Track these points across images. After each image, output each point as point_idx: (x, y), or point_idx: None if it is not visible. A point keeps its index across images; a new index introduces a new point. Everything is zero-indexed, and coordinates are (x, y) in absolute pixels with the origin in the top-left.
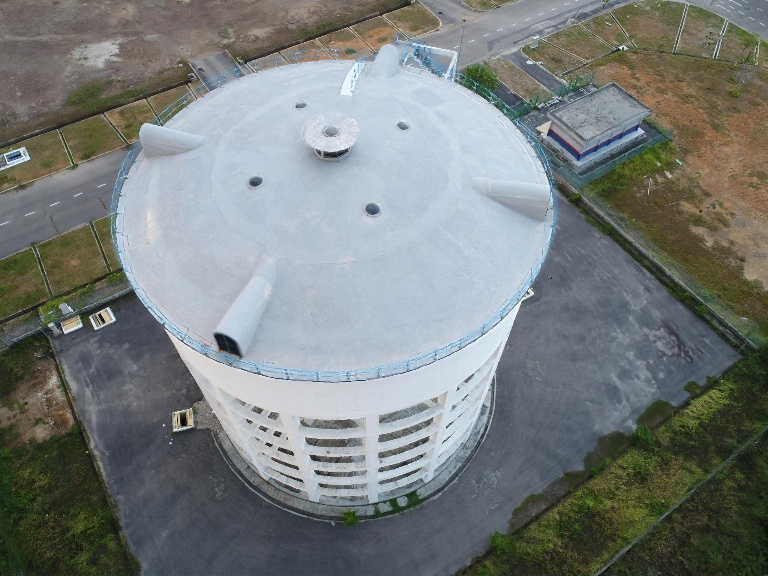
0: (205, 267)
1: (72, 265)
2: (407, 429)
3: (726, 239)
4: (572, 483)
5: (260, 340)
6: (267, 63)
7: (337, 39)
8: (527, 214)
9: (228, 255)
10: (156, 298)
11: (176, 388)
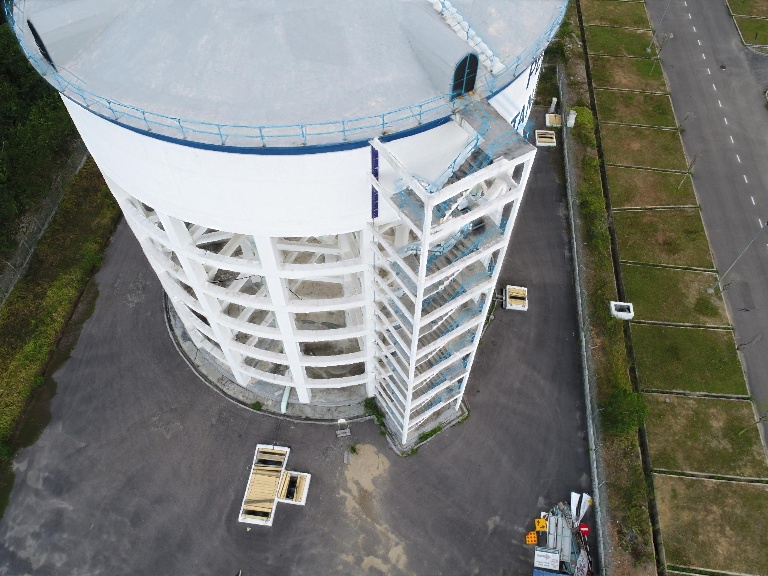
0: None
1: (633, 144)
2: None
3: None
4: (58, 355)
5: None
6: None
7: None
8: None
9: None
10: None
11: None
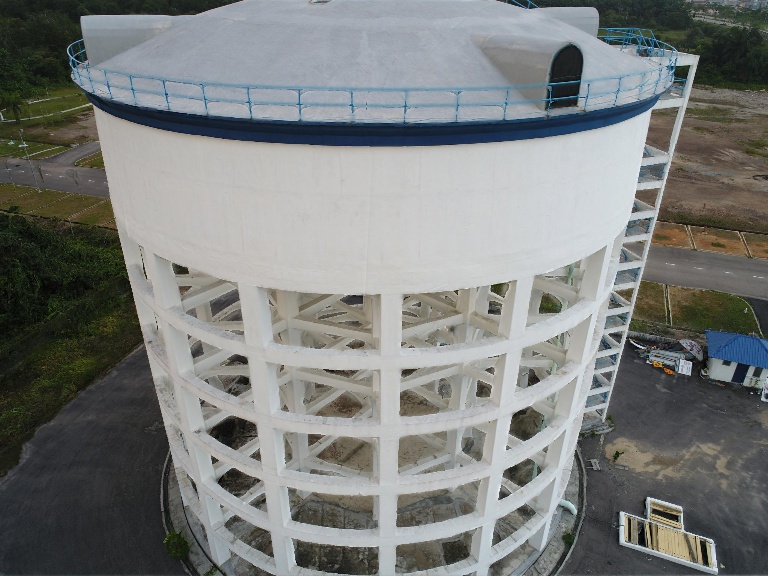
0: None
1: None
2: None
3: None
4: None
5: (112, 58)
6: None
7: (714, 233)
8: (522, 89)
9: None
10: None
11: None
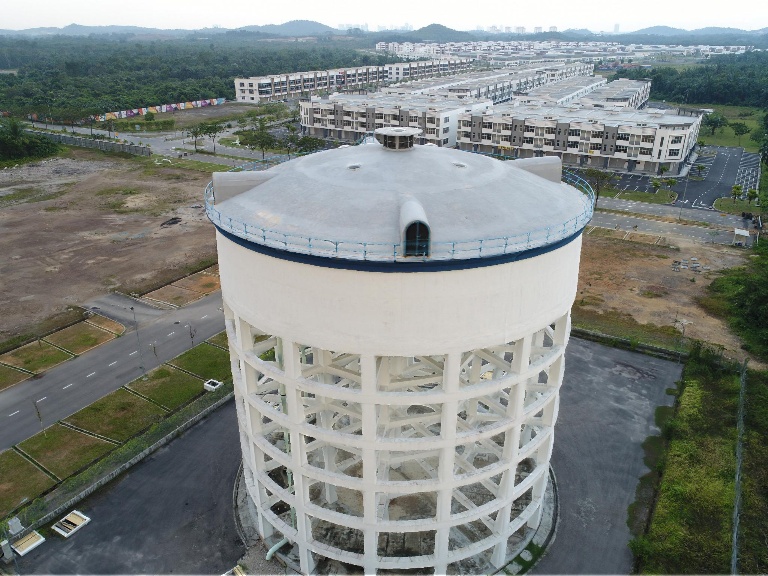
0: (351, 214)
1: (3, 490)
2: (484, 494)
3: (609, 307)
4: (652, 483)
5: (437, 242)
6: (163, 292)
7: None
8: (549, 178)
9: (368, 202)
10: (313, 248)
11: (206, 555)
